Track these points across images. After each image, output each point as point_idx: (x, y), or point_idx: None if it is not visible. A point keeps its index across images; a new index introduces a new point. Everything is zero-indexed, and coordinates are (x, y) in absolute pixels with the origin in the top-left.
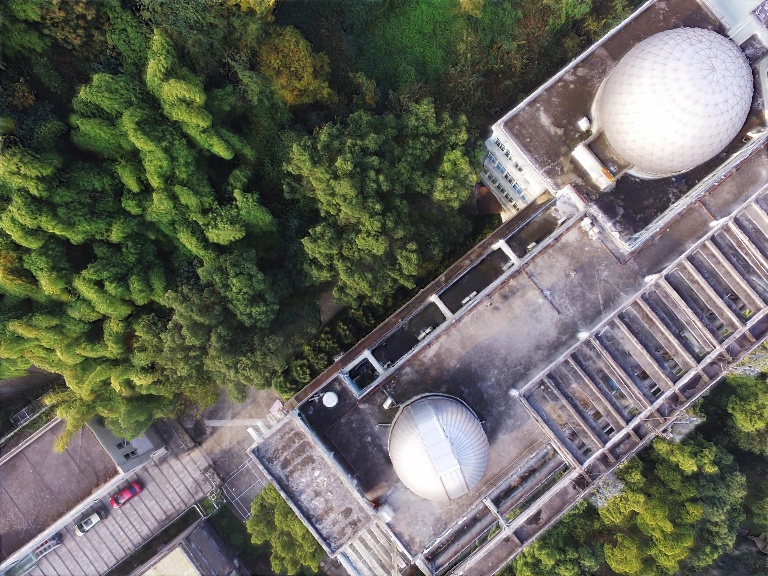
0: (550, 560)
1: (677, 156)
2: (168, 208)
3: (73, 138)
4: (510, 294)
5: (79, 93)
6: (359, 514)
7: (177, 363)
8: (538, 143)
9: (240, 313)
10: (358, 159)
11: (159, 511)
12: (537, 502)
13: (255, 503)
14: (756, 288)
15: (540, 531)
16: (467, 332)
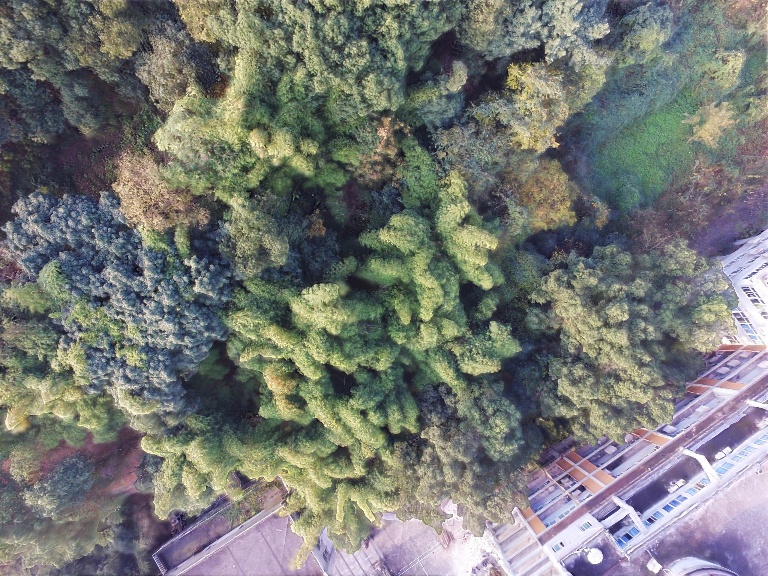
0: None
1: None
2: (435, 341)
3: (362, 272)
4: None
5: (373, 229)
6: None
7: (431, 497)
8: None
9: (495, 451)
10: None
11: None
12: None
13: None
14: None
15: None
16: (735, 498)
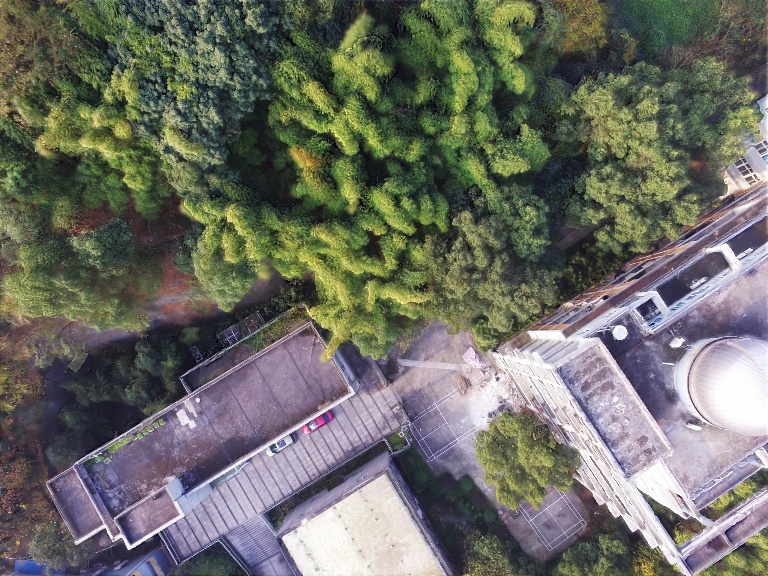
0: None
1: None
2: None
3: (401, 52)
4: None
5: (413, 9)
6: (655, 443)
7: (460, 283)
8: None
9: (523, 243)
10: None
11: (346, 442)
12: None
13: (488, 435)
14: None
15: None
16: (757, 283)
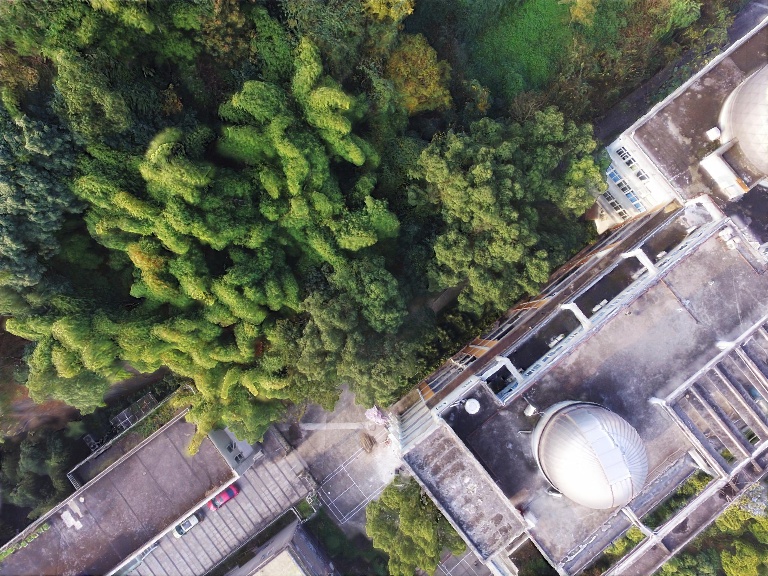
0: (673, 568)
1: None
2: (306, 214)
3: (221, 144)
4: (649, 303)
5: (228, 100)
6: (509, 521)
7: (313, 368)
8: (666, 152)
9: (375, 319)
10: (493, 167)
11: (255, 514)
12: (684, 510)
13: (374, 508)
14: None
15: (689, 539)
16: (606, 340)
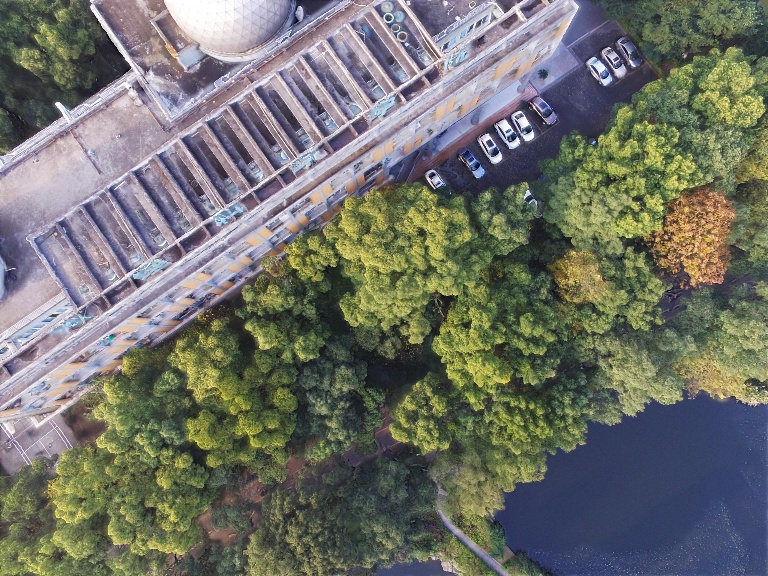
0: (118, 424)
1: (204, 25)
2: None
3: None
4: (57, 152)
5: None
6: None
7: None
8: (131, 23)
9: None
10: None
11: None
12: None
13: None
14: (271, 155)
15: (29, 365)
16: (11, 185)
